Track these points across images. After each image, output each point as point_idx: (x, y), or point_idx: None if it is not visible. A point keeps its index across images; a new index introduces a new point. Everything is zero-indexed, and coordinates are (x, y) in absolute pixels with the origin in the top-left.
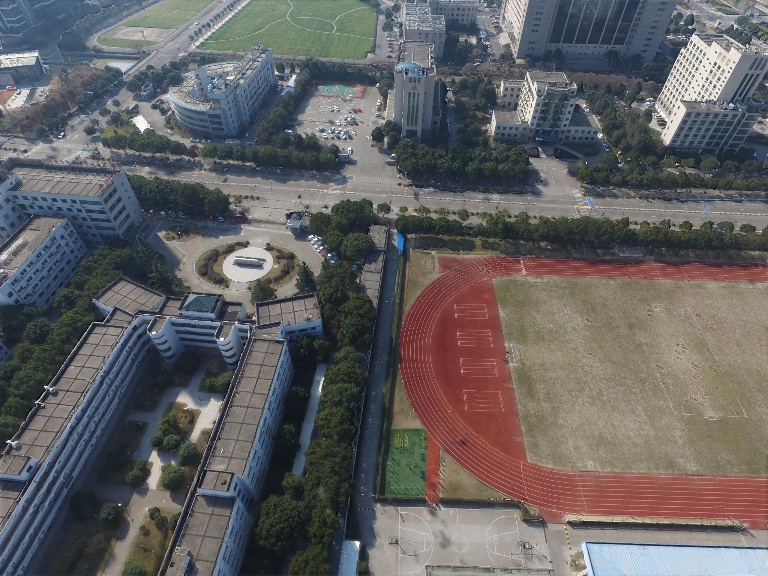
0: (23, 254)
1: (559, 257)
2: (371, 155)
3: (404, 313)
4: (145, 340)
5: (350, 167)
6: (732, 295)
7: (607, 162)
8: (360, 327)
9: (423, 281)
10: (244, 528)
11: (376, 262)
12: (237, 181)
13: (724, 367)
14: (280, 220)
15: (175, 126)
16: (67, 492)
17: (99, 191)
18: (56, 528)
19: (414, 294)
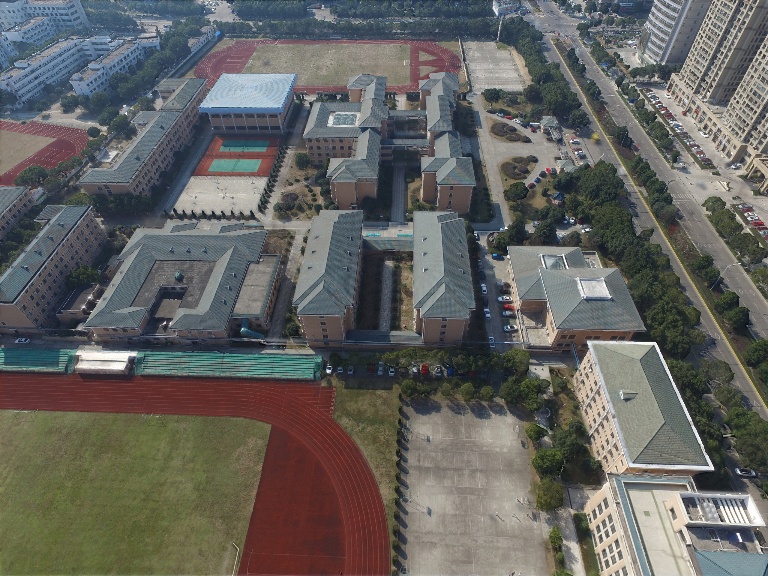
0: (29, 25)
1: (298, 39)
2: (225, 10)
3: (207, 54)
4: (82, 56)
5: (211, 15)
6: (373, 47)
7: (349, 4)
8: (175, 44)
9: (223, 46)
10: (108, 89)
11: (199, 37)
12: (146, 21)
13: (344, 64)
14: (163, 32)
15: (119, 3)
16: (44, 90)
17: (65, 2)
18: (39, 97)
19: (216, 50)
